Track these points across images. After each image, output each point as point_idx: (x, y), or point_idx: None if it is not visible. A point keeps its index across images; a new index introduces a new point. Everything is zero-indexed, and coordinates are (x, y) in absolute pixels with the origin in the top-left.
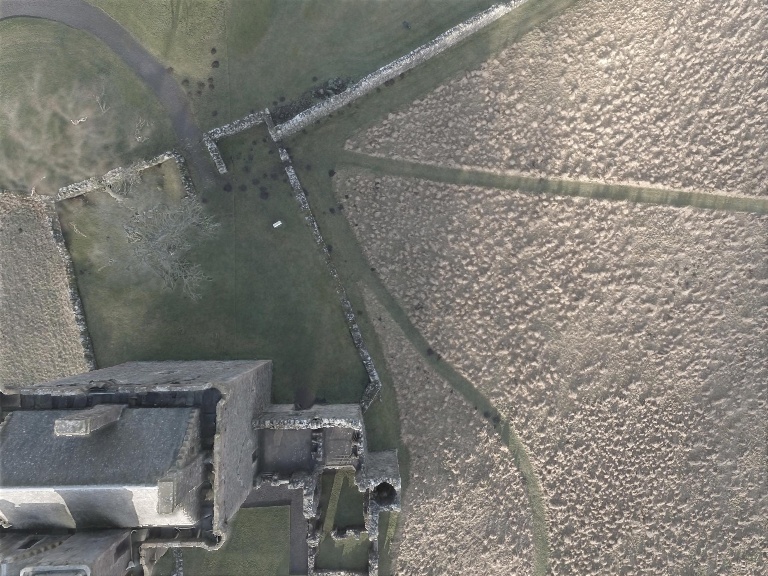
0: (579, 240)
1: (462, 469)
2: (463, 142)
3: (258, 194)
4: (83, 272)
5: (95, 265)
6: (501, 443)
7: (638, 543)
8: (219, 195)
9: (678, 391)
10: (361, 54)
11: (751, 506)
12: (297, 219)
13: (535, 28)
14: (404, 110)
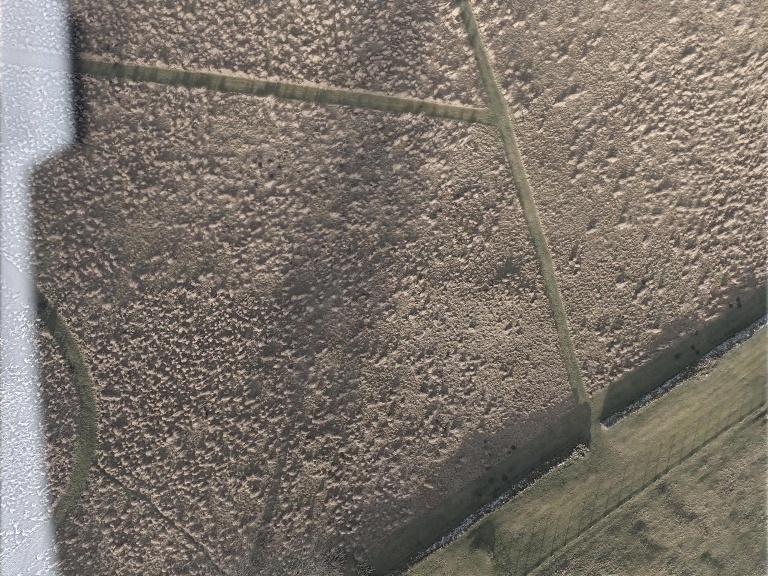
0: (153, 127)
1: None
2: (30, 22)
3: None
4: None
5: None
6: (43, 329)
7: (199, 438)
8: None
9: (256, 285)
10: None
11: (328, 405)
12: None
13: None
14: None
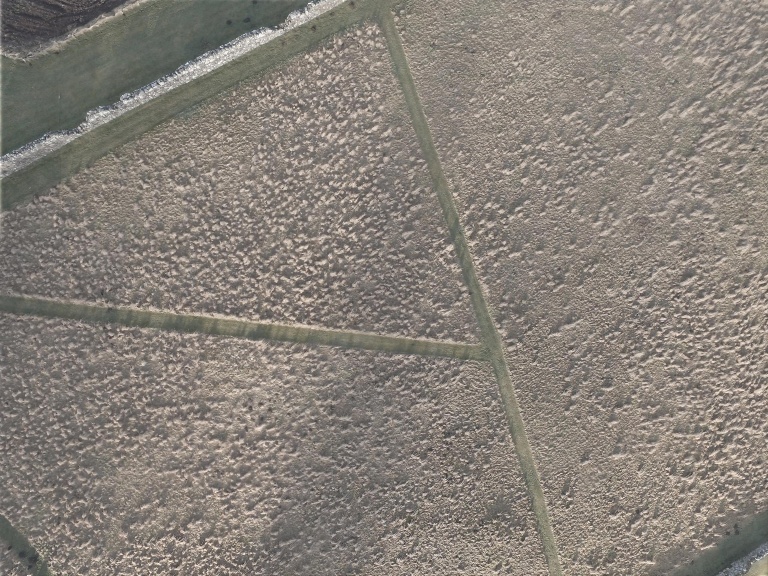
0: (145, 372)
1: None
2: (26, 270)
3: None
4: None
5: None
6: None
7: None
8: None
9: (244, 530)
10: None
11: None
12: None
13: (109, 153)
14: None
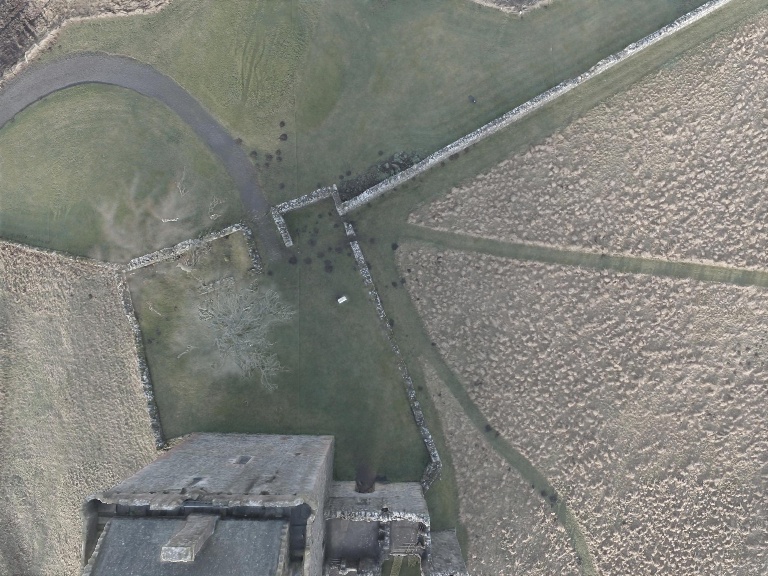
0: (640, 317)
1: (519, 549)
2: (525, 217)
3: (322, 267)
4: (151, 341)
5: (163, 334)
6: (558, 523)
7: None
8: (284, 267)
9: (737, 473)
10: (426, 128)
11: None
12: (360, 293)
13: (601, 103)
14: (467, 184)
